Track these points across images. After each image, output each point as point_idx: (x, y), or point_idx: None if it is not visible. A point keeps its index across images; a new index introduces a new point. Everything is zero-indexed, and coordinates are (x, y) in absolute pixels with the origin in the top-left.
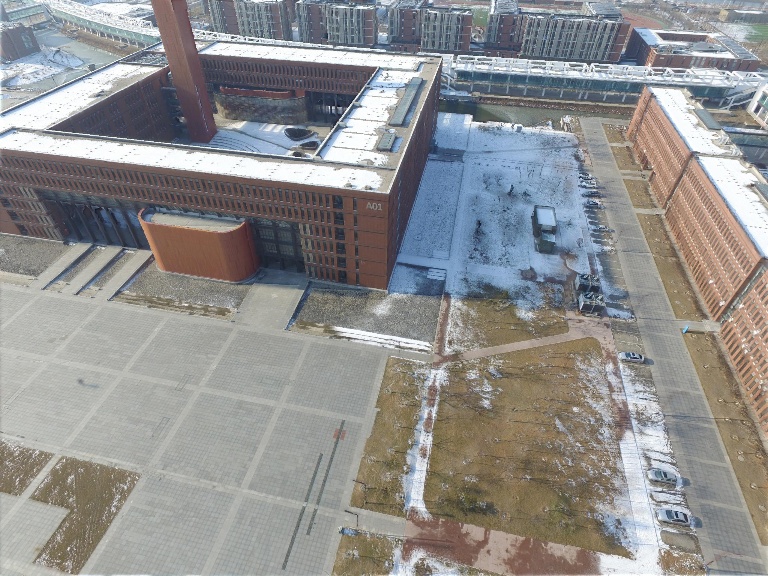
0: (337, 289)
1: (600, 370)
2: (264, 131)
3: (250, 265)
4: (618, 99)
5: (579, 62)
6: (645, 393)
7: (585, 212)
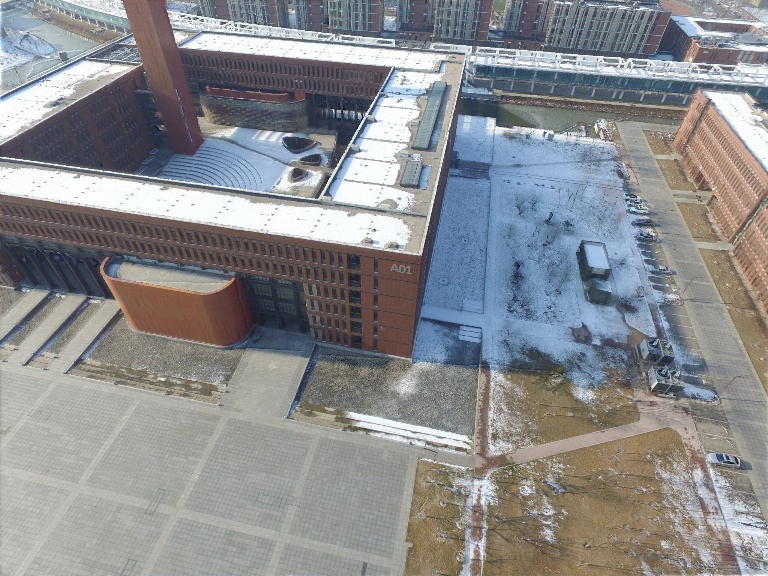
0: (350, 356)
1: (687, 479)
2: (258, 140)
3: (242, 325)
4: (657, 99)
5: (614, 57)
6: (748, 515)
7: (638, 247)
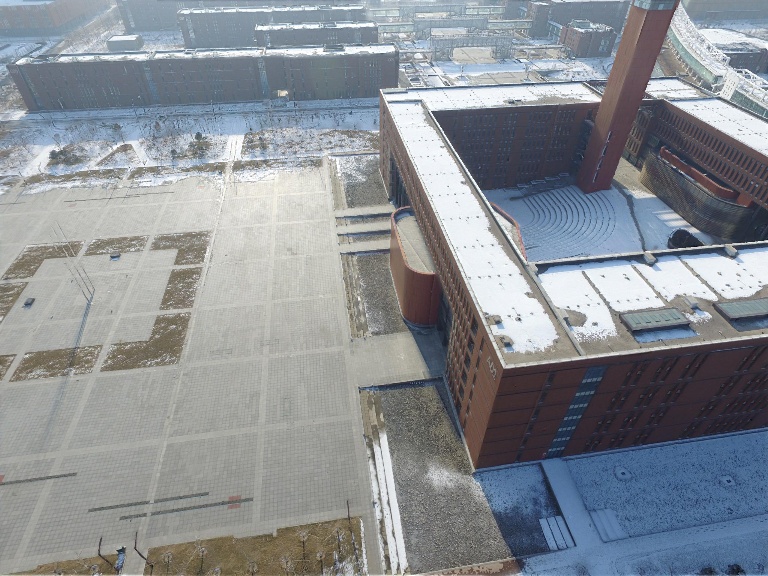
0: (447, 411)
1: None
2: (655, 216)
3: (423, 314)
4: None
5: None
6: None
7: None
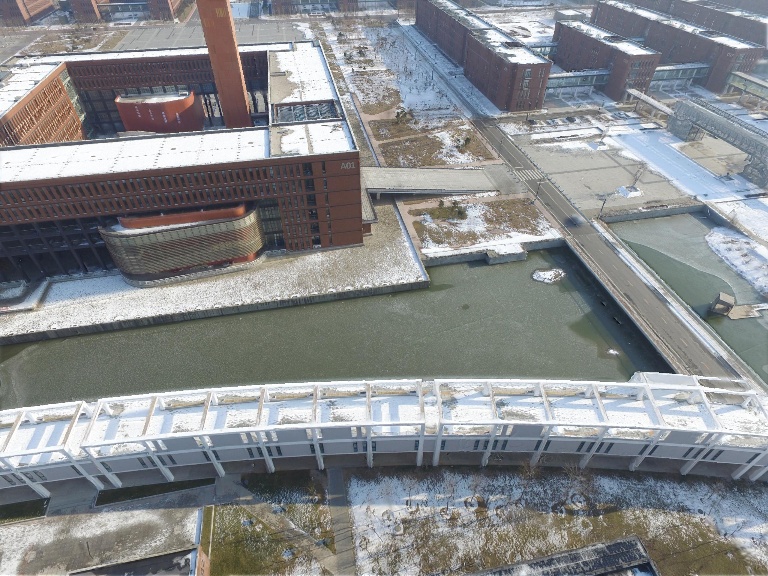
0: None
1: None
2: None
3: None
4: None
5: None
6: None
7: None
